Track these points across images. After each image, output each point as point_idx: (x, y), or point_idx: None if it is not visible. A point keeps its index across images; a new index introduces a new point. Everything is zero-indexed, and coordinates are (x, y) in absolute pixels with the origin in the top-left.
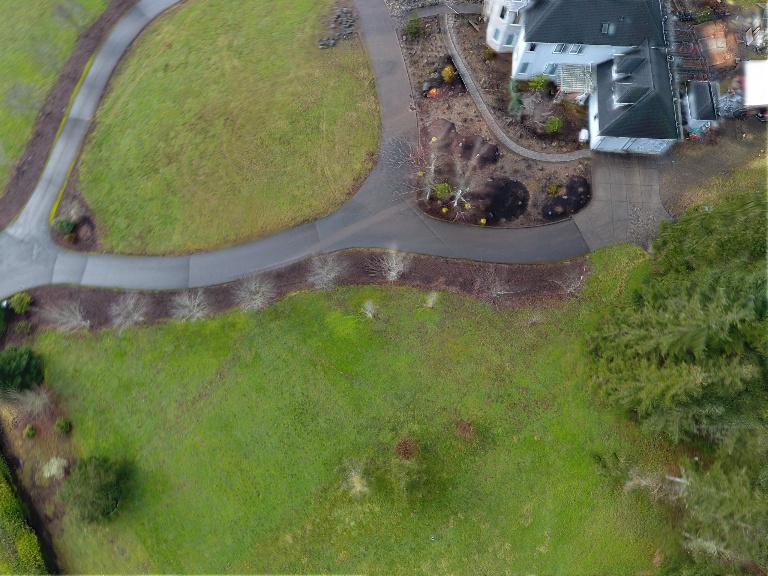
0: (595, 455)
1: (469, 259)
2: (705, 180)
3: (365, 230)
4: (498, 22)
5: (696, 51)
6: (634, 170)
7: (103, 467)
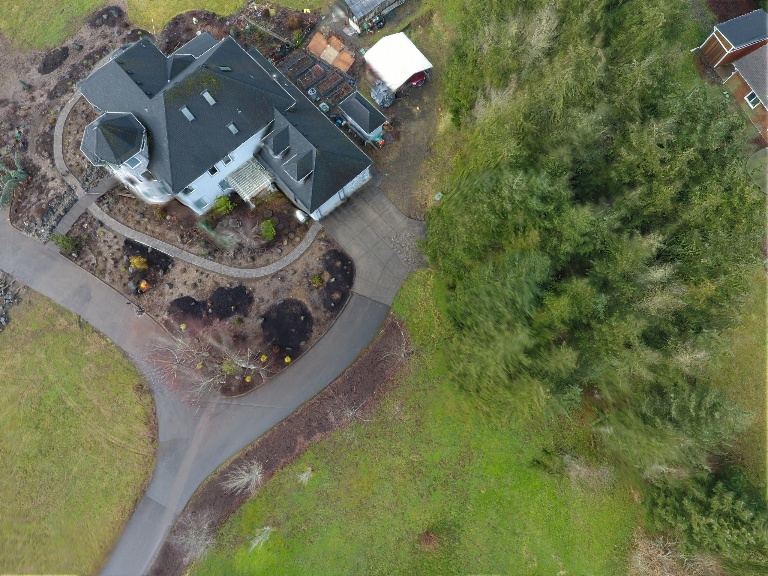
0: (532, 461)
1: (305, 402)
2: (421, 169)
3: (197, 459)
4: (142, 184)
5: (327, 67)
6: (364, 208)
7: None
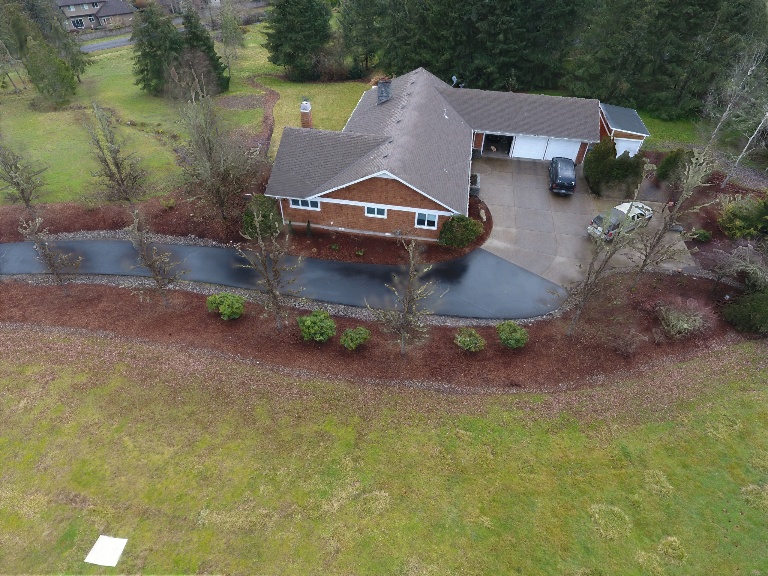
0: None
1: None
2: None
3: None
4: None
5: None
6: None
7: (328, 5)
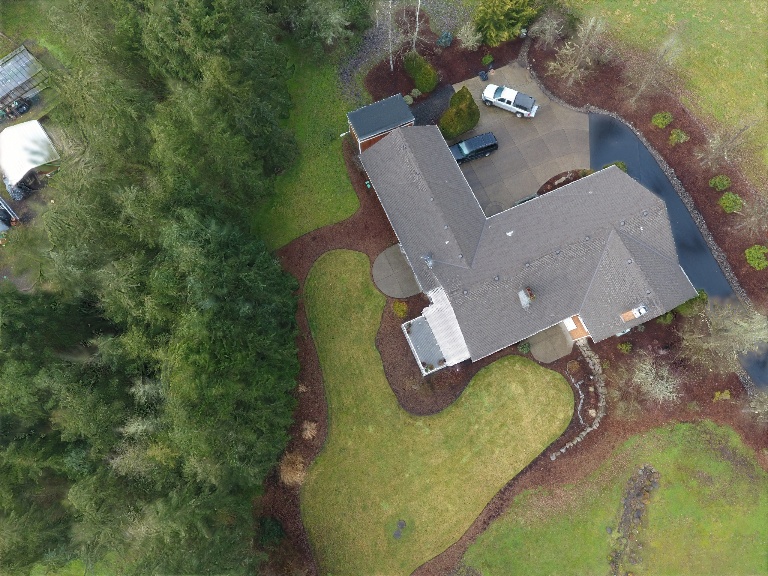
0: None
1: None
2: None
3: None
4: None
5: None
6: None
7: None
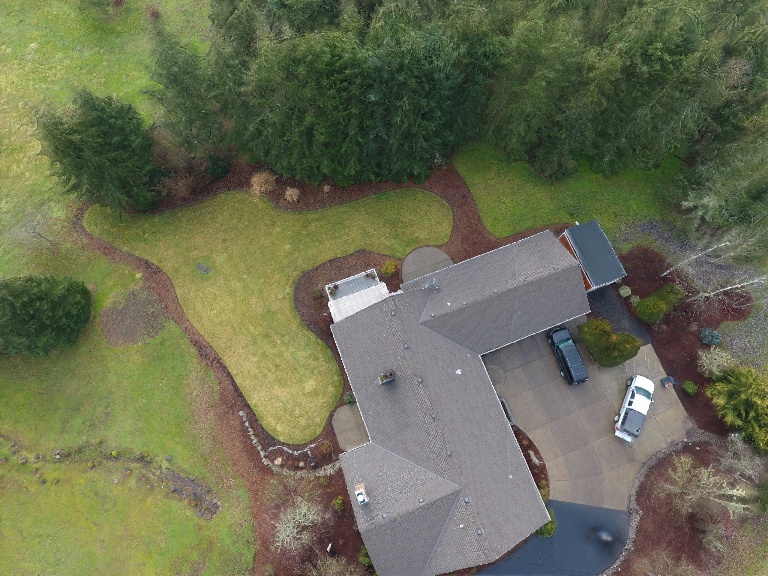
0: None
1: None
2: None
3: None
4: None
5: None
6: None
7: None
